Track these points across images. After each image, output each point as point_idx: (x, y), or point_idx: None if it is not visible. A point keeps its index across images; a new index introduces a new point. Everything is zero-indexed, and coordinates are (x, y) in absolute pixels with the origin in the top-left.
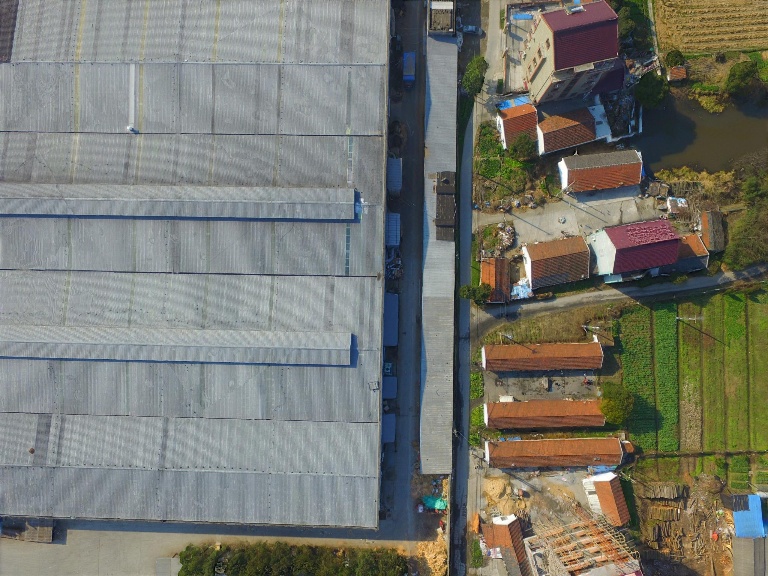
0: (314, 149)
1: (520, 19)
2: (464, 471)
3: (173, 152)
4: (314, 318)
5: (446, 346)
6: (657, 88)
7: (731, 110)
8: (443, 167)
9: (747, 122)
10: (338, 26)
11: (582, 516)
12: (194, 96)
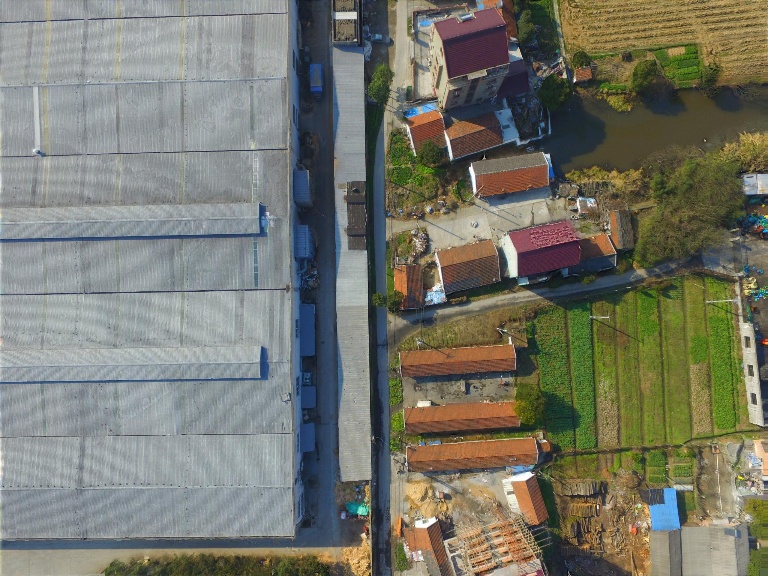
0: (219, 165)
1: (427, 26)
2: (386, 476)
3: (80, 173)
4: (225, 333)
5: (362, 354)
6: (558, 91)
7: (639, 108)
8: (353, 177)
9: (655, 120)
10: (239, 41)
11: (501, 516)
12: (98, 116)
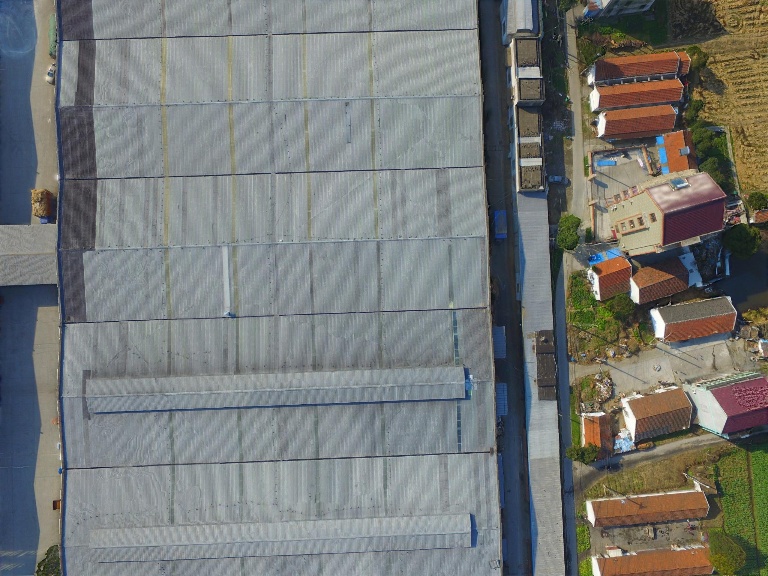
0: (418, 325)
1: (604, 165)
2: None
3: (273, 335)
4: (430, 499)
5: (555, 507)
6: (751, 243)
7: None
8: (541, 326)
9: None
10: (434, 197)
11: None
12: (291, 276)
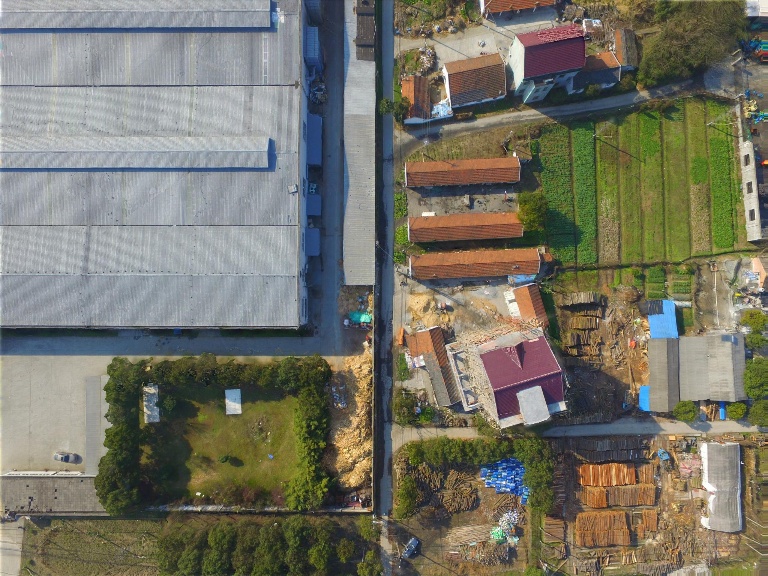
0: None
1: None
2: (389, 288)
3: None
4: (233, 125)
5: (368, 162)
6: None
7: None
8: None
9: None
10: None
11: (502, 323)
12: None
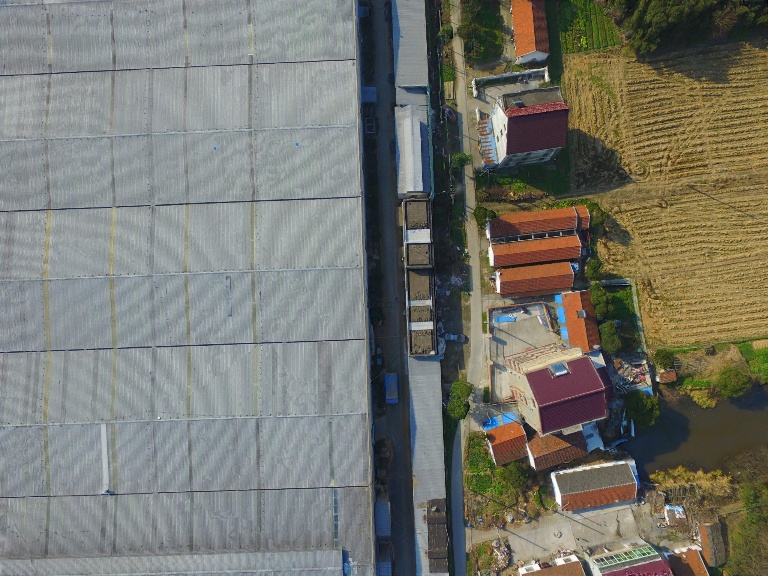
0: (298, 504)
1: (503, 322)
2: None
3: (151, 514)
4: None
5: None
6: (648, 416)
7: (724, 404)
8: (432, 494)
9: (741, 416)
10: (315, 371)
11: None
12: (170, 454)
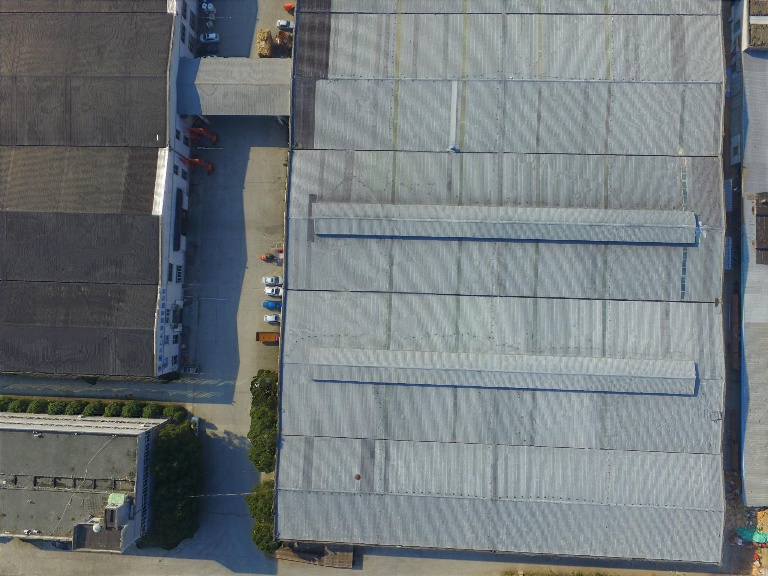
0: (645, 170)
1: None
2: None
3: (497, 172)
4: (650, 345)
5: None
6: None
7: None
8: (761, 188)
9: None
10: (668, 42)
11: None
12: (519, 114)
